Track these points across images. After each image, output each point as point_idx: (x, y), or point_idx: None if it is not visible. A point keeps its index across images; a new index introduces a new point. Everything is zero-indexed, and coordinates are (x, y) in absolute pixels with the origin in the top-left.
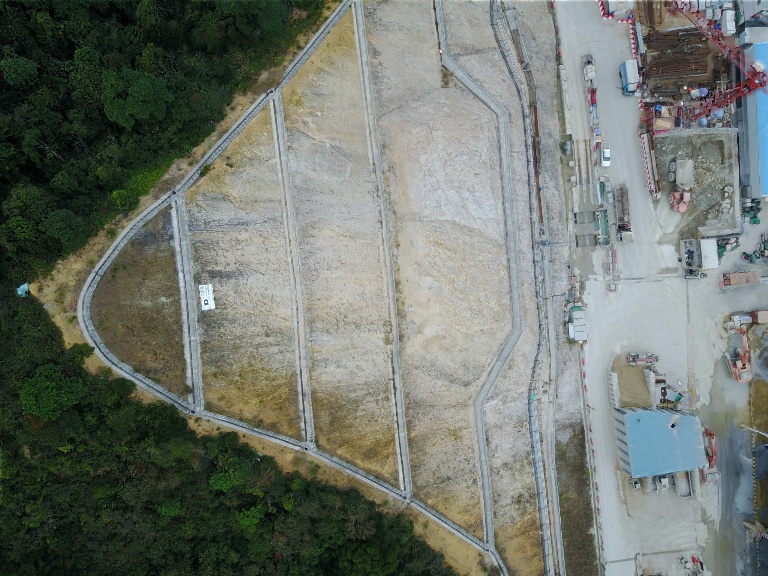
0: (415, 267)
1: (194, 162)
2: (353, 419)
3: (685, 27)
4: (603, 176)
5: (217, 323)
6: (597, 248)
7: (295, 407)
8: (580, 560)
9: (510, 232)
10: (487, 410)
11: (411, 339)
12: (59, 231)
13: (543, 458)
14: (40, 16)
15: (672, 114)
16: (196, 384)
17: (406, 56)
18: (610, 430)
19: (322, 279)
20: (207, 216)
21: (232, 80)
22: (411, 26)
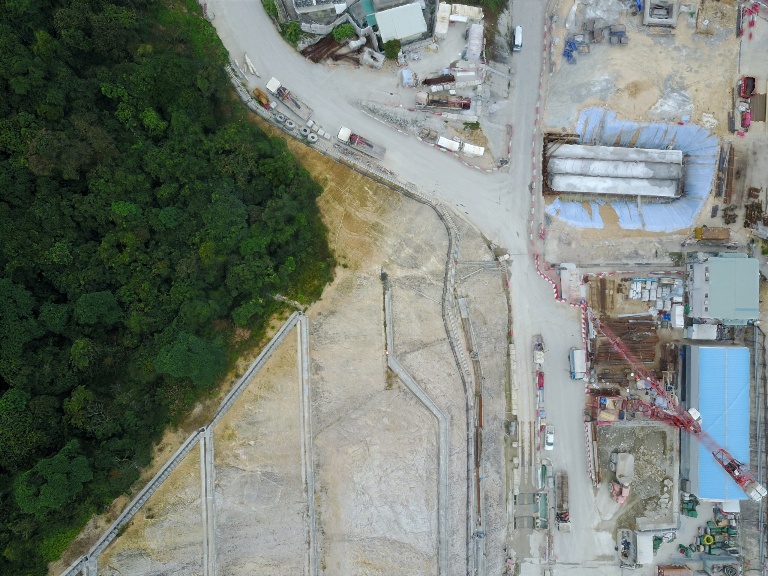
0: None
1: (112, 519)
2: None
3: (636, 314)
4: (545, 459)
5: None
6: (535, 531)
7: None
8: None
9: (443, 540)
10: None
11: None
12: None
13: None
14: None
15: (616, 407)
16: None
17: (350, 364)
18: None
19: None
20: None
21: (163, 420)
22: (358, 332)
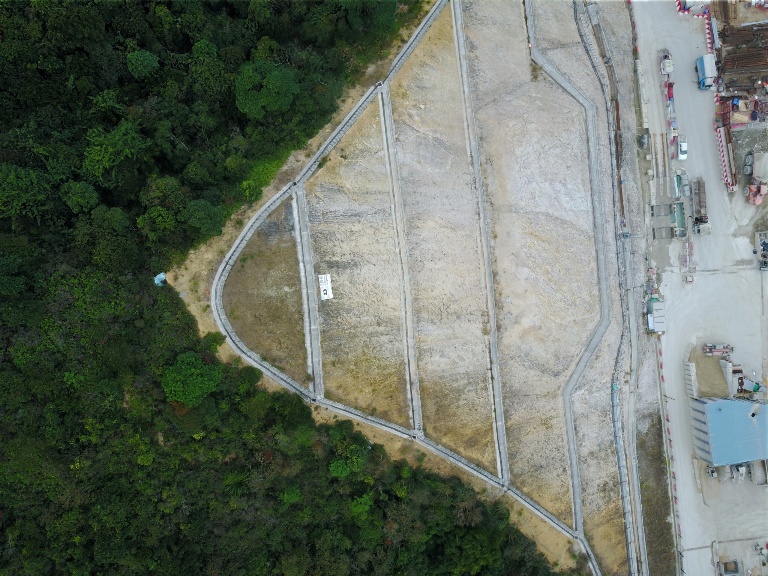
0: (512, 258)
1: (311, 154)
2: (456, 408)
3: (759, 22)
4: (680, 169)
5: (335, 313)
6: (674, 240)
7: (404, 396)
8: (659, 548)
9: (598, 224)
10: (575, 400)
11: (508, 329)
12: (201, 221)
13: (625, 447)
14: (159, 9)
15: (749, 108)
16: (316, 373)
17: (499, 50)
18: (686, 420)
19: (427, 270)
20: (325, 207)
21: (342, 73)
22: (503, 20)
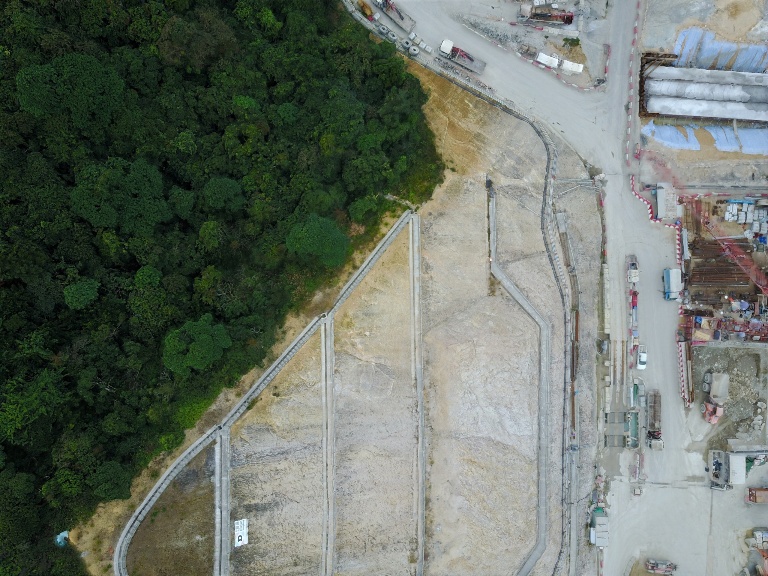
0: (447, 485)
1: (242, 393)
2: None
3: (731, 237)
4: (637, 378)
5: (248, 558)
6: (625, 450)
7: None
8: None
9: (543, 446)
10: None
11: (436, 558)
12: (107, 492)
13: None
14: (106, 235)
15: (712, 327)
16: None
17: (457, 267)
18: None
19: (355, 502)
20: (250, 449)
21: (287, 303)
22: (464, 236)
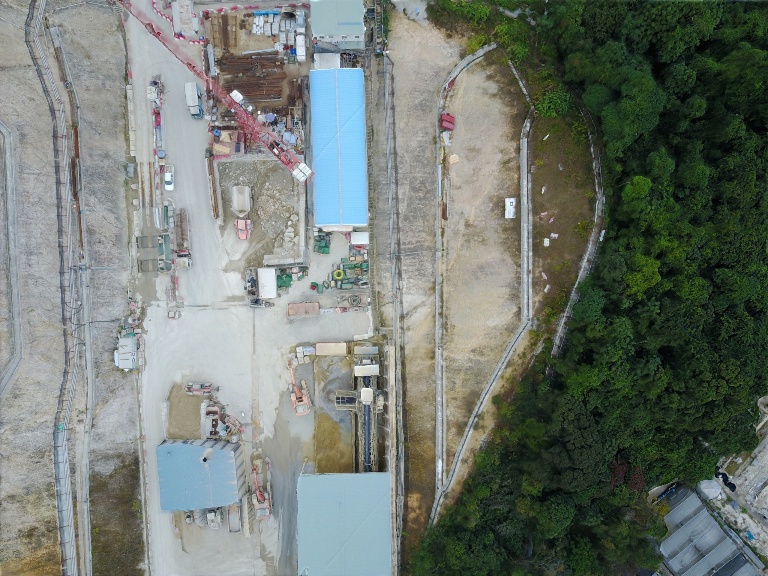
0: None
1: None
2: None
3: (261, 51)
4: (167, 200)
5: None
6: (159, 273)
7: None
8: None
9: (13, 256)
10: None
11: None
12: None
13: (74, 490)
14: None
15: (232, 139)
16: None
17: None
18: None
19: None
20: None
21: None
22: None
